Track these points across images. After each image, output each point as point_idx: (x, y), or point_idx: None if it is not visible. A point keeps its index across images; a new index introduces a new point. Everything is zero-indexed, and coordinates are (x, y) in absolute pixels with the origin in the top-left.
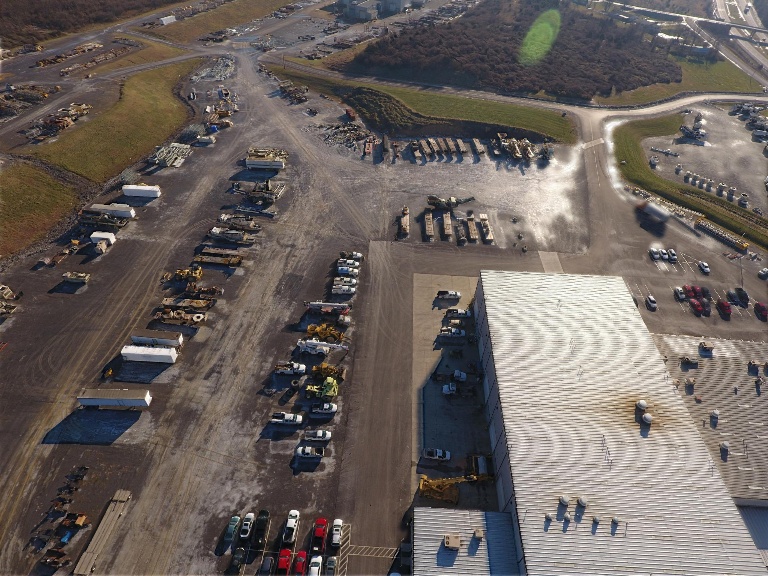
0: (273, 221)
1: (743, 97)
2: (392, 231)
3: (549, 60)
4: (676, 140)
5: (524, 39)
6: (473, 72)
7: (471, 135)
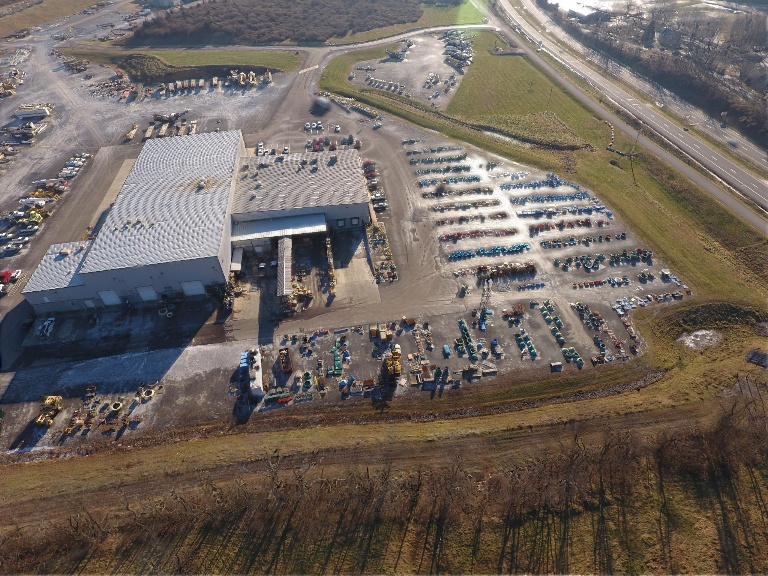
0: (30, 147)
1: (460, 26)
2: (121, 140)
3: (303, 17)
4: (382, 61)
5: None
6: (229, 32)
7: (213, 76)
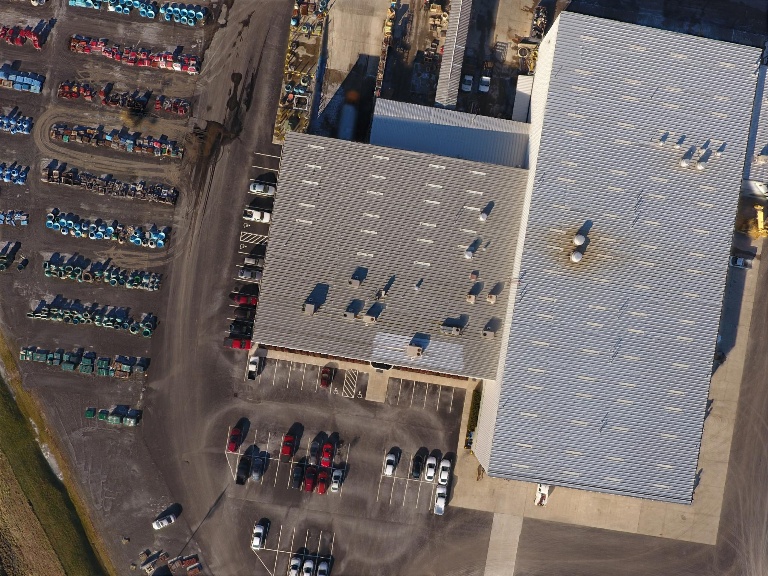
0: None
1: None
2: None
3: None
4: None
5: None
6: None
7: None
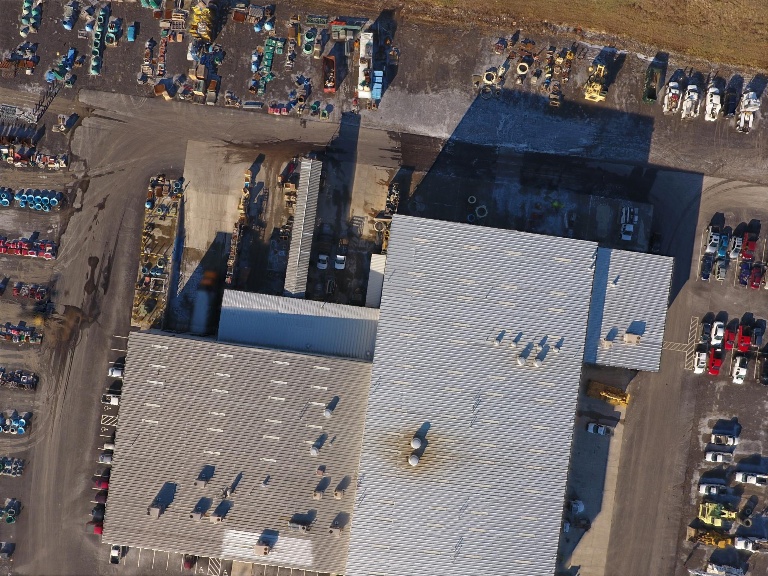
0: None
1: None
2: None
3: None
4: None
5: None
6: None
7: None
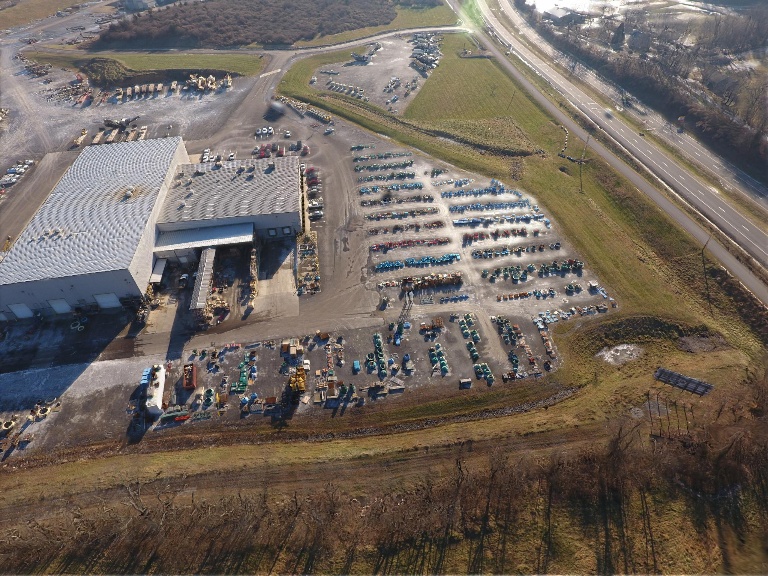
0: None
1: (432, 29)
2: (68, 146)
3: (273, 19)
4: (347, 64)
5: (262, 6)
6: (195, 35)
7: (173, 80)
